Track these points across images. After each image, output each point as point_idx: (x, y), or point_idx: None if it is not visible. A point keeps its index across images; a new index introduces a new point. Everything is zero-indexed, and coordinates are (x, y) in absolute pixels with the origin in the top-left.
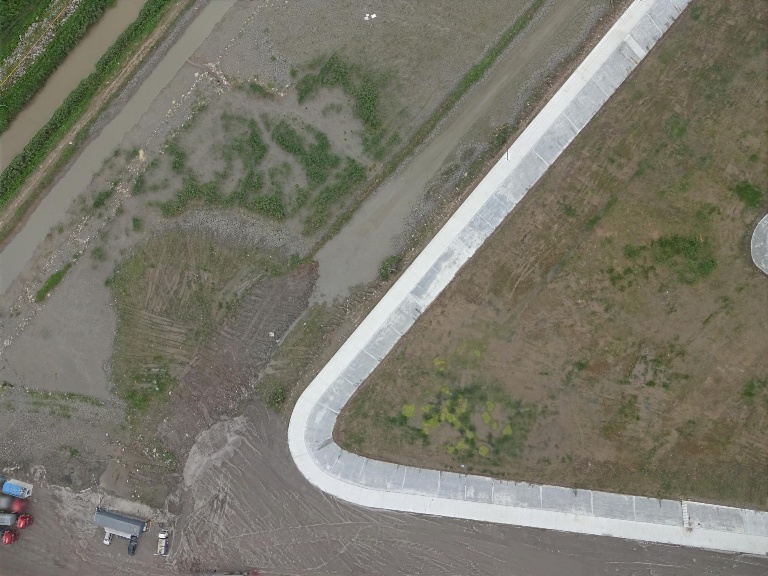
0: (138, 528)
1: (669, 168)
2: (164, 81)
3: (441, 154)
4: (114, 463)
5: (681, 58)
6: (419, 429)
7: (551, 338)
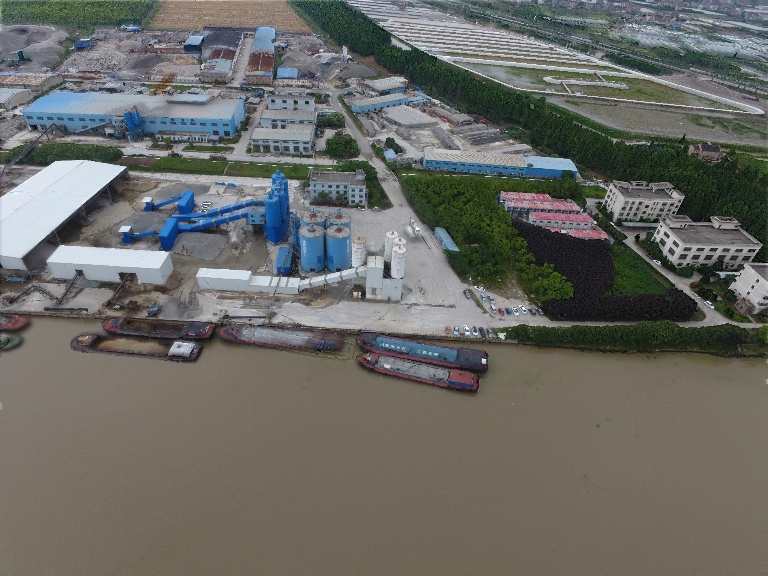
0: None
1: None
2: (757, 144)
3: None
4: None
5: None
6: None
7: None
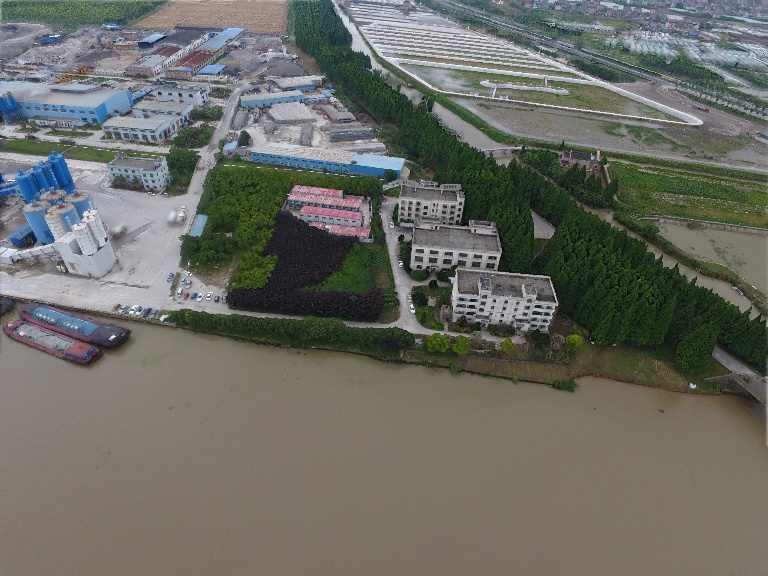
0: (762, 133)
1: None
2: None
3: None
4: (759, 145)
5: None
6: (665, 116)
7: None
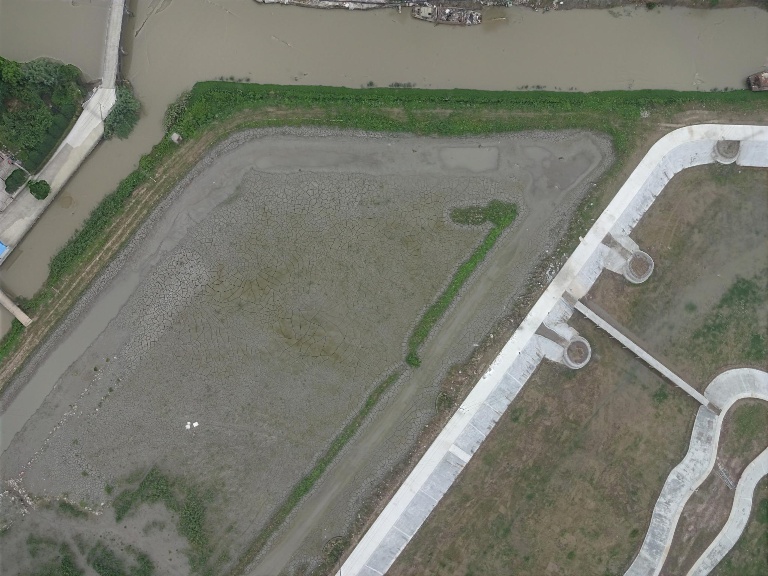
0: None
1: (496, 569)
2: None
3: (273, 571)
4: None
5: (503, 459)
6: None
7: None
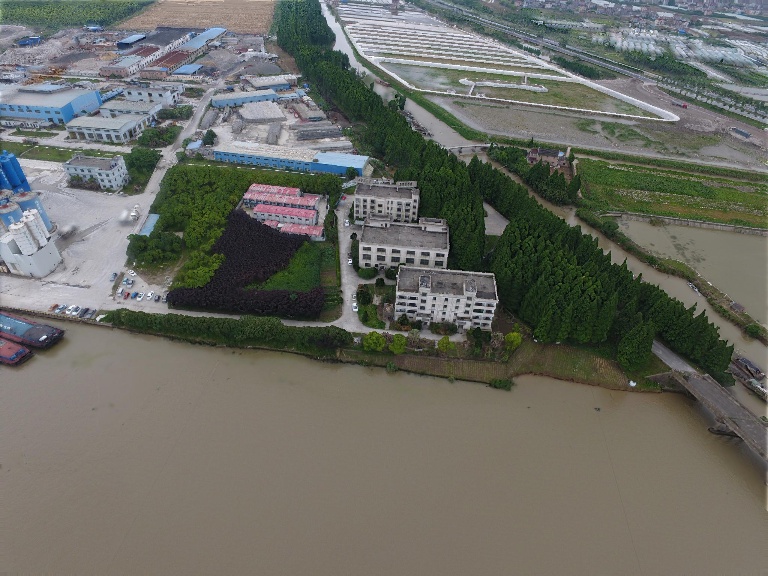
0: None
1: None
2: None
3: (580, 116)
4: None
5: None
6: None
7: (597, 104)
